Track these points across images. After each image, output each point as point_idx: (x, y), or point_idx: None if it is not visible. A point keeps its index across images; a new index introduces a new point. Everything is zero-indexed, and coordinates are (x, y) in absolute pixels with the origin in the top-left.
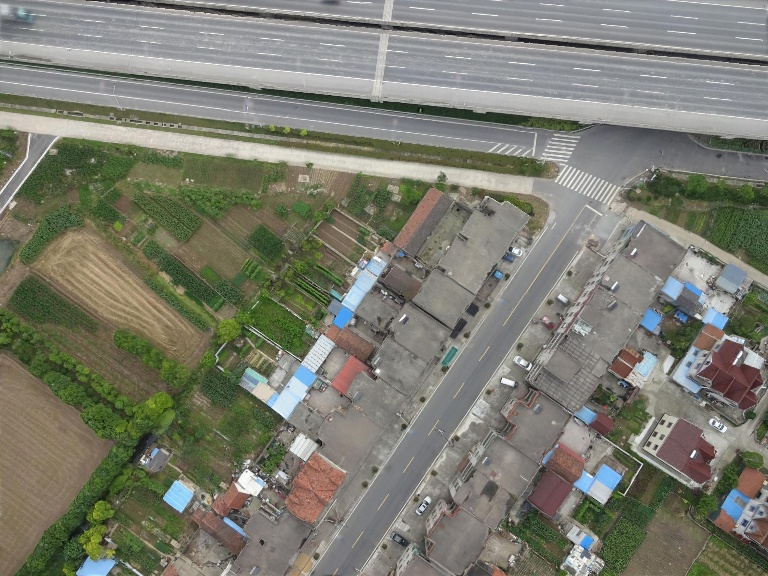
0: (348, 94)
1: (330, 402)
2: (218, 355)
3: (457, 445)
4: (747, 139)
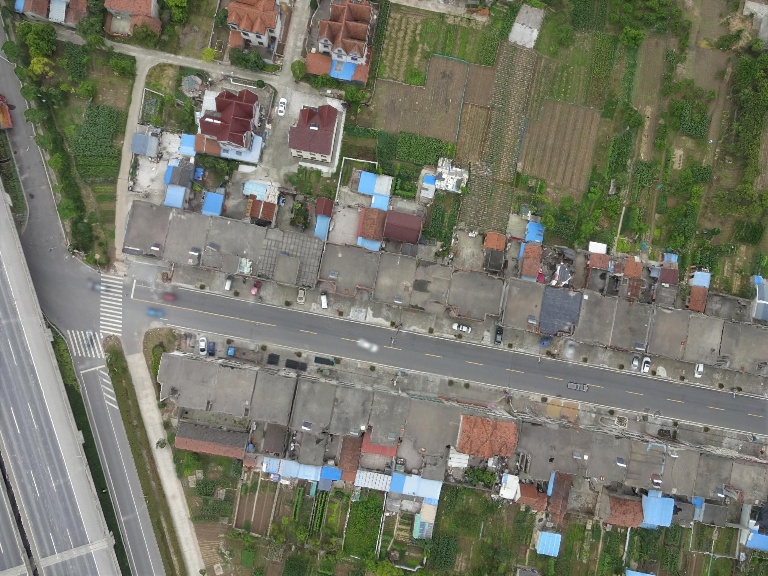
0: (117, 571)
1: (411, 449)
2: (414, 568)
3: (398, 321)
4: (4, 178)
